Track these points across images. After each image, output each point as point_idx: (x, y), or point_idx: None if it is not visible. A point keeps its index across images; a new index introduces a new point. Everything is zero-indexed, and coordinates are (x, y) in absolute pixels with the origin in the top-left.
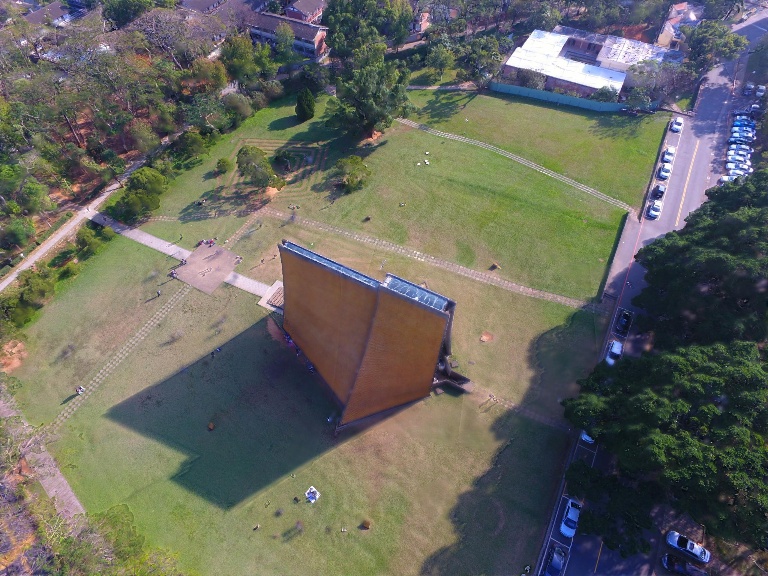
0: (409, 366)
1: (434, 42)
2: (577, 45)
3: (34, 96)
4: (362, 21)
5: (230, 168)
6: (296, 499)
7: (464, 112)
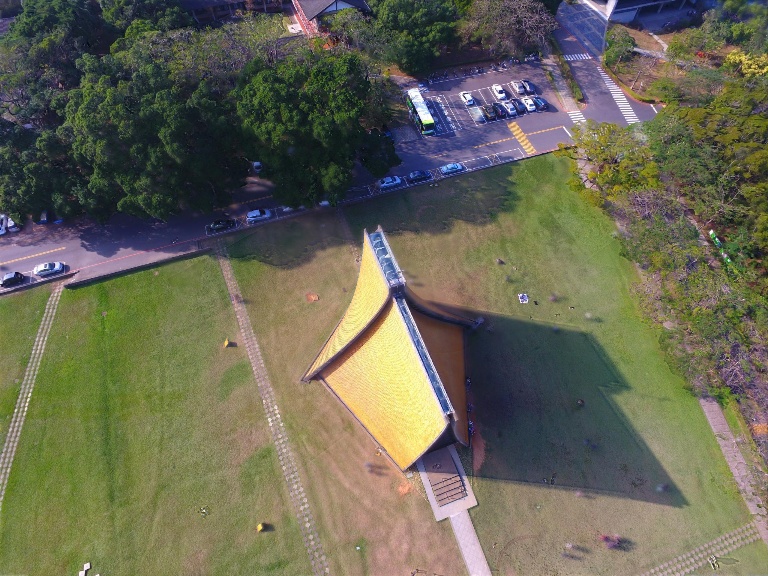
0: None
1: None
2: None
3: None
4: None
5: None
6: (536, 303)
7: None
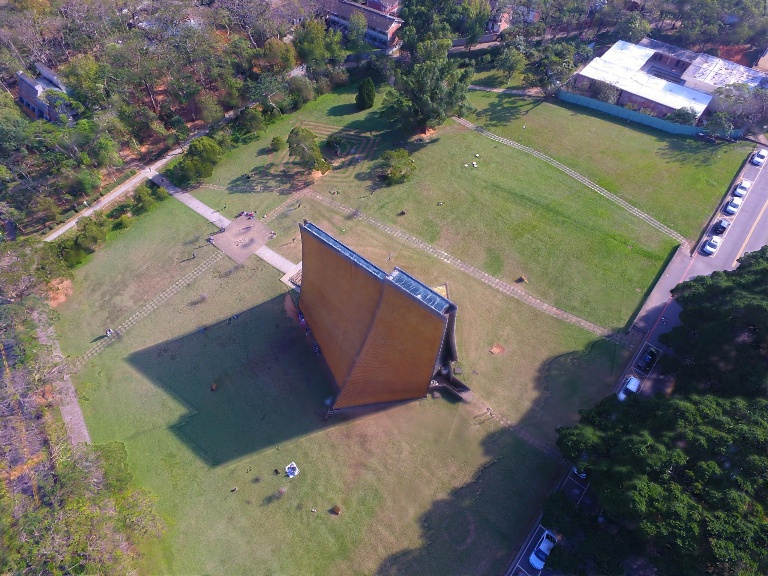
0: (407, 363)
1: (508, 44)
2: (664, 61)
3: (122, 60)
4: (435, 16)
5: (283, 147)
6: (276, 471)
7: (525, 118)
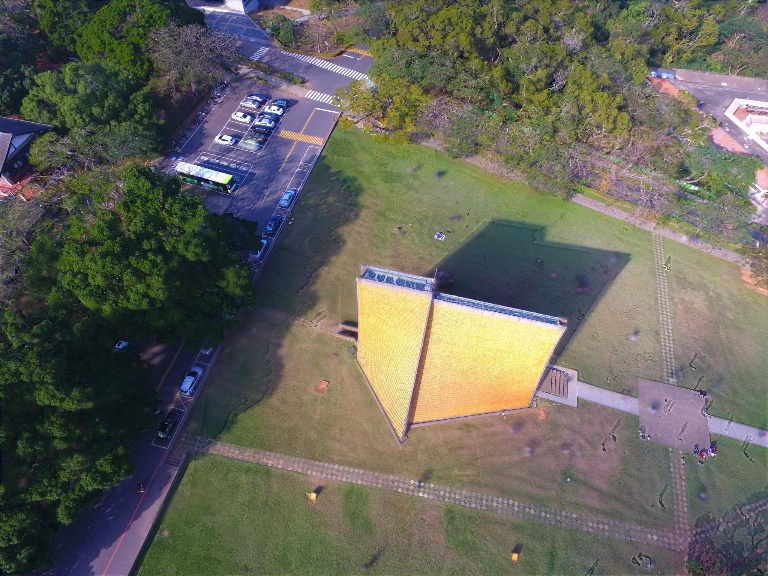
0: None
1: None
2: None
3: None
4: None
5: None
6: (450, 232)
7: None
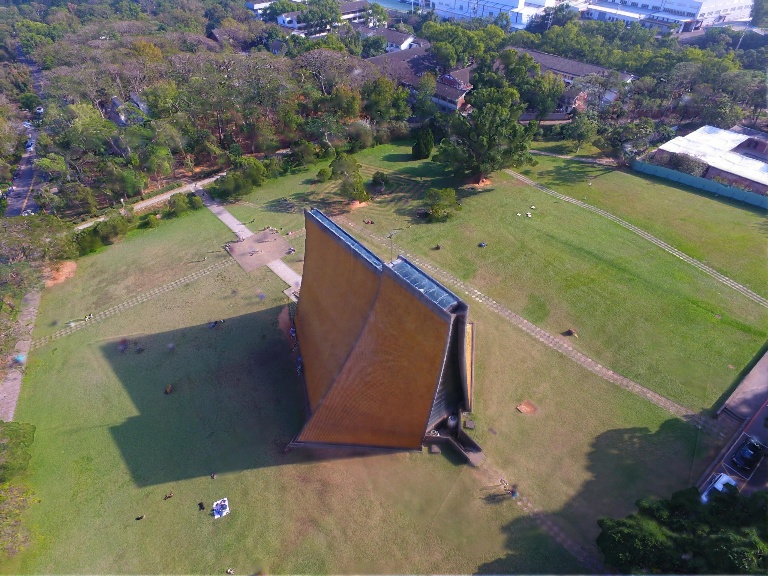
0: (398, 391)
1: None
2: (760, 149)
3: None
4: (505, 81)
5: (329, 180)
6: (200, 505)
7: (592, 182)
